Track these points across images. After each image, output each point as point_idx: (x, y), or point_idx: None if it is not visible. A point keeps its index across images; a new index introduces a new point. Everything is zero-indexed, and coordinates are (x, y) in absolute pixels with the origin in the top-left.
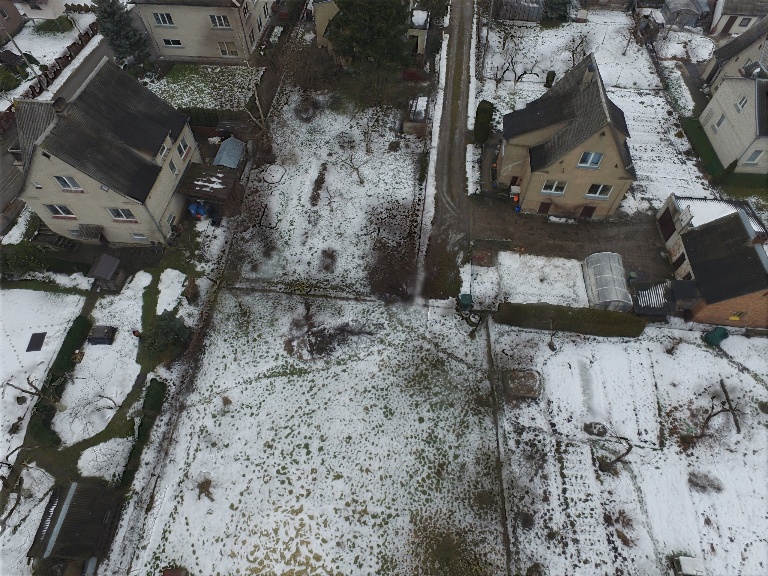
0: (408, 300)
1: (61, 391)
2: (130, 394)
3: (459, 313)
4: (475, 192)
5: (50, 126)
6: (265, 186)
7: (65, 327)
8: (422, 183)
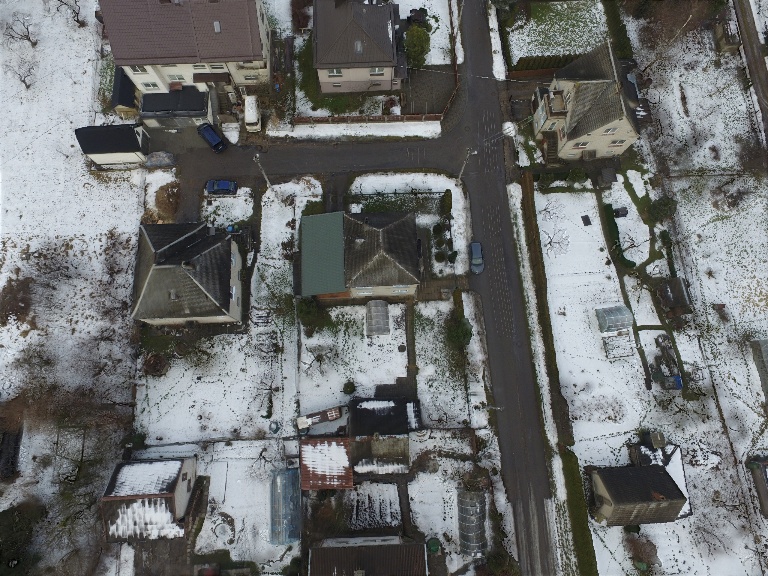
0: (765, 171)
1: None
2: (651, 239)
3: None
4: None
5: None
6: (652, 106)
7: (595, 211)
8: (747, 92)
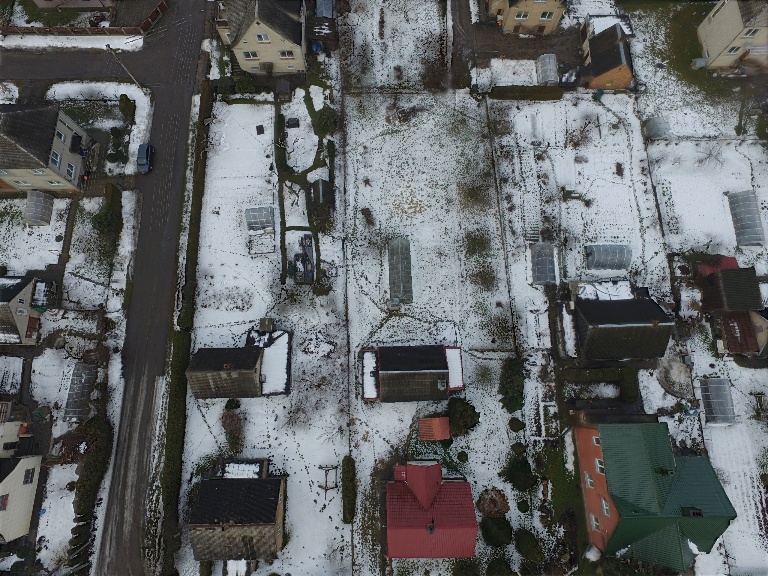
0: (444, 91)
1: (284, 151)
2: None
3: (471, 95)
4: (476, 22)
5: (256, 5)
6: (349, 28)
7: (271, 121)
8: (444, 18)
